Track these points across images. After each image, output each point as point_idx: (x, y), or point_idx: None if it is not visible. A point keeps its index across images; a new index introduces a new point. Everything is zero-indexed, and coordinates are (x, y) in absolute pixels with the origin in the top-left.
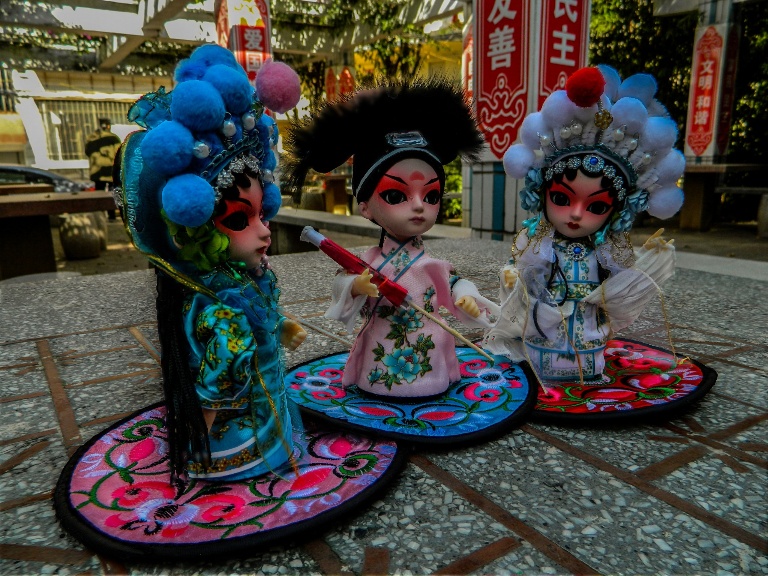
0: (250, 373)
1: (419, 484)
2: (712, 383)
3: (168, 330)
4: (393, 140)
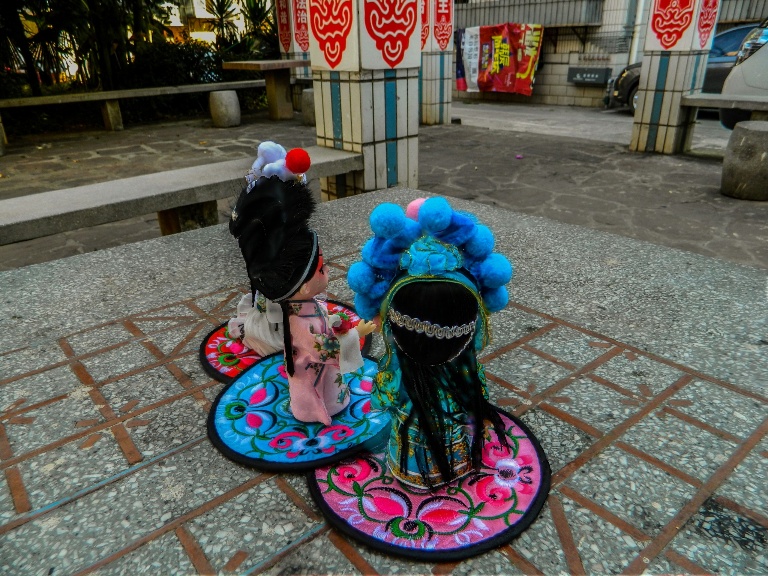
0: None
1: None
2: None
3: None
4: None
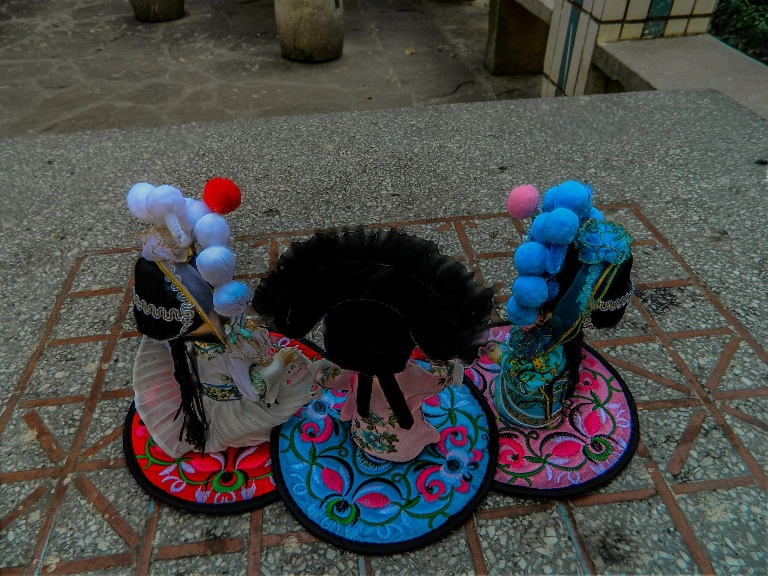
0: None
1: None
2: None
3: None
4: None
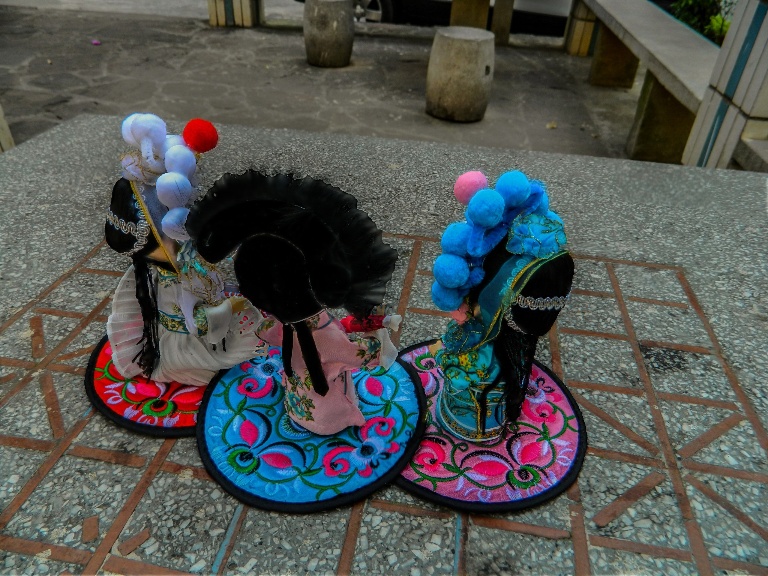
0: None
1: None
2: None
3: None
4: None
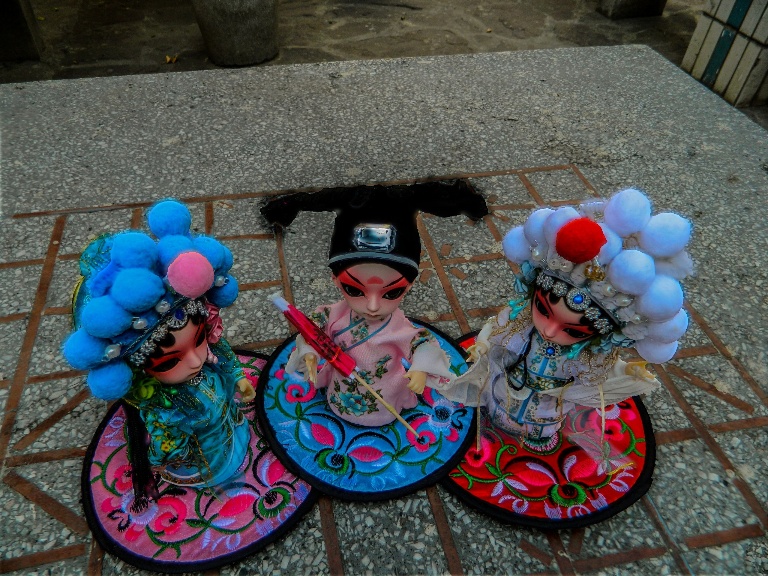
0: (190, 445)
1: (308, 534)
2: (624, 507)
3: (128, 414)
4: (358, 240)
